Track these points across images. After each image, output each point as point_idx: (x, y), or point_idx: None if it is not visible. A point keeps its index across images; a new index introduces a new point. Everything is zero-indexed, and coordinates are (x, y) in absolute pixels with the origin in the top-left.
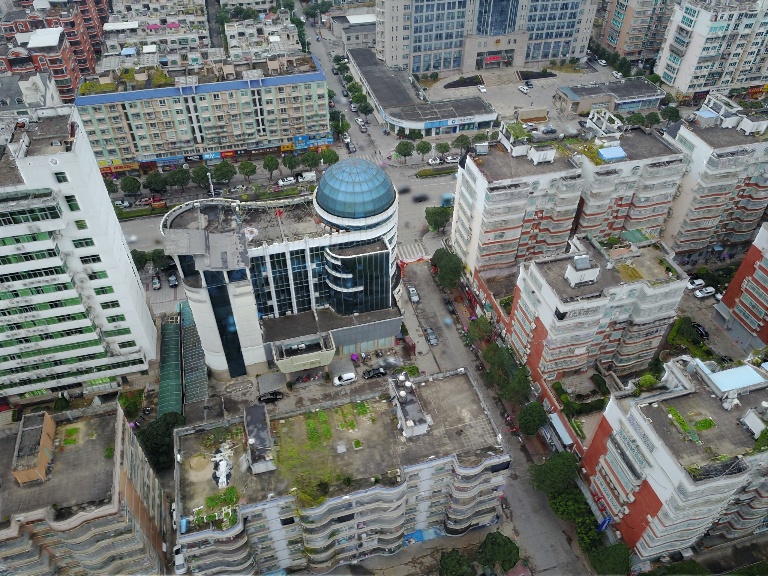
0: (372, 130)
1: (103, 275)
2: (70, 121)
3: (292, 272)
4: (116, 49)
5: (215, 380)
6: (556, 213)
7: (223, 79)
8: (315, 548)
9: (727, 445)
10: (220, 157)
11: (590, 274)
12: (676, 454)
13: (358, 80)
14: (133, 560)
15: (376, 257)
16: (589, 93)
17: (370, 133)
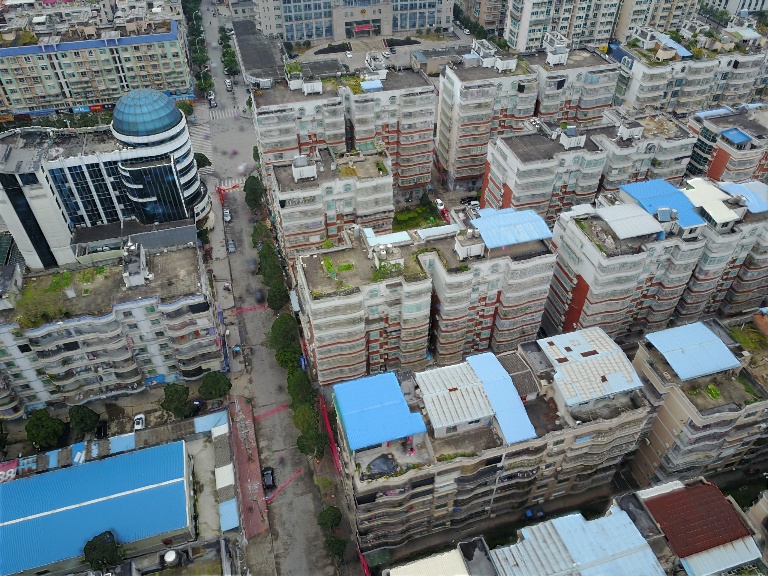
0: (237, 89)
1: None
2: None
3: (93, 184)
4: None
5: None
6: (327, 137)
7: (85, 39)
8: (54, 374)
9: (356, 280)
10: (89, 111)
11: (308, 171)
12: (313, 286)
13: None
14: None
15: (160, 170)
16: (437, 55)
17: (235, 92)
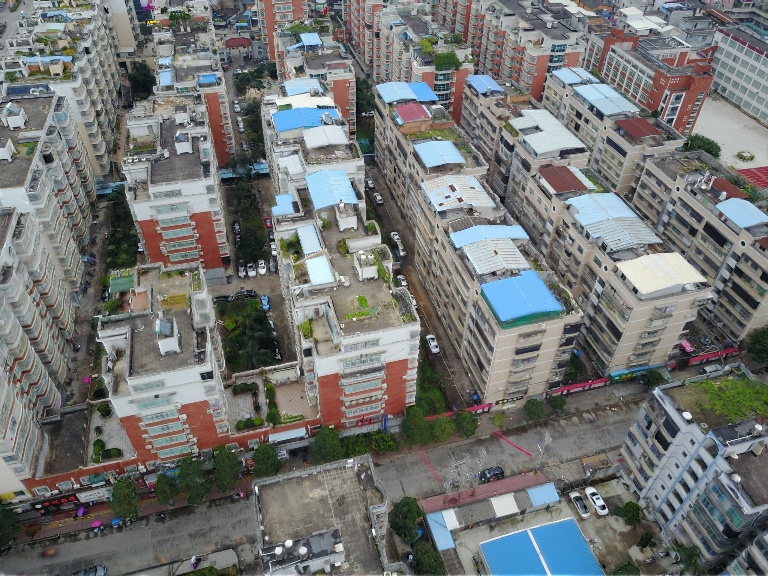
0: None
1: None
2: None
3: None
4: None
5: None
6: (17, 350)
7: None
8: None
9: (382, 295)
10: None
11: None
12: (390, 326)
13: None
14: None
15: None
16: None
17: None
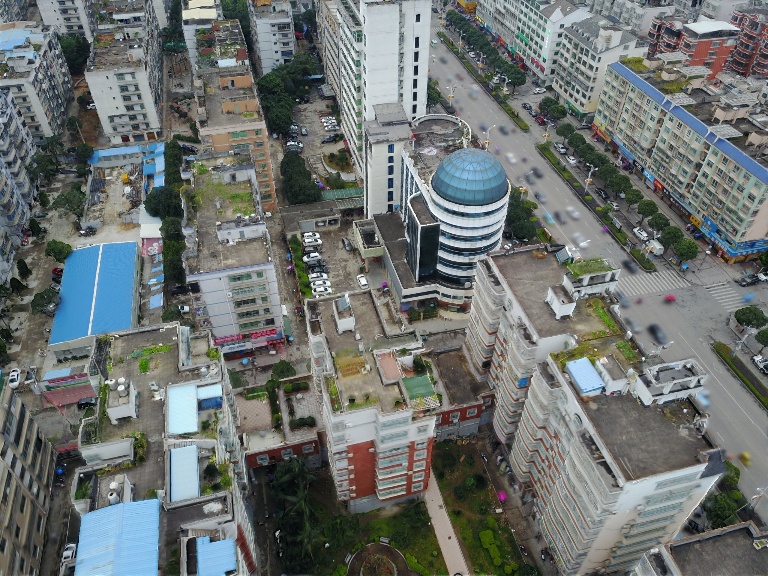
0: None
1: None
2: (406, 1)
3: (410, 192)
4: None
5: None
6: None
7: (710, 120)
8: None
9: (120, 376)
10: (653, 182)
11: None
12: (127, 339)
13: None
14: None
15: None
16: None
17: None
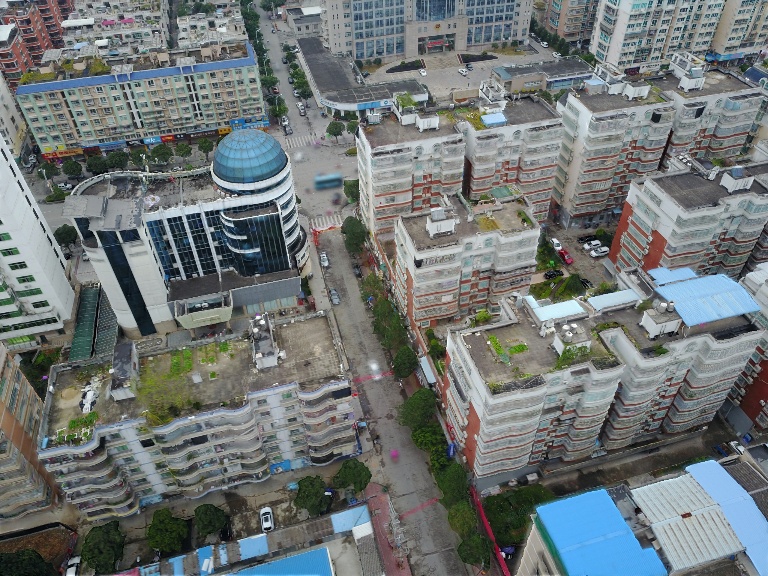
0: (311, 113)
1: (7, 237)
2: None
3: (192, 235)
4: (73, 45)
5: (128, 338)
6: (443, 177)
7: (158, 67)
8: (177, 469)
9: (534, 366)
10: (161, 141)
11: (446, 225)
12: (485, 374)
13: (305, 68)
14: (14, 481)
15: (267, 219)
16: (522, 73)
17: (309, 116)
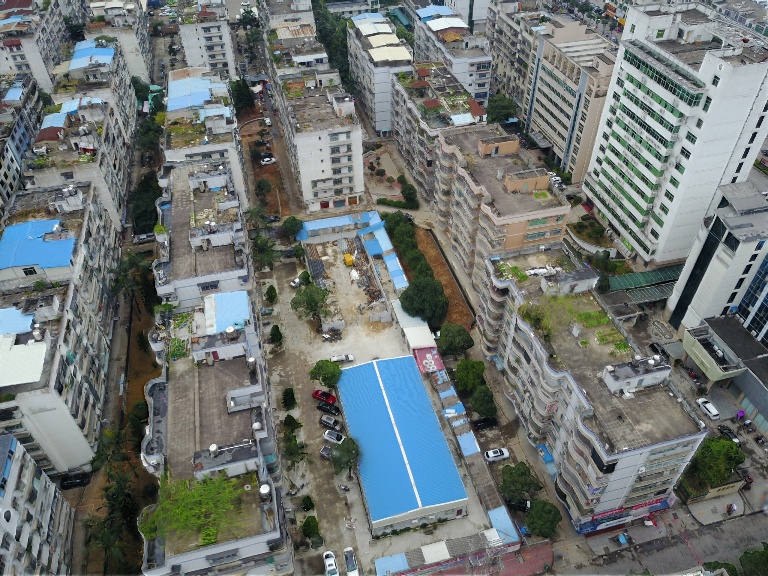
0: None
1: (682, 171)
2: None
3: None
4: None
5: (662, 312)
6: None
7: None
8: (509, 358)
9: None
10: None
11: None
12: None
13: None
14: None
15: None
16: None
17: None
